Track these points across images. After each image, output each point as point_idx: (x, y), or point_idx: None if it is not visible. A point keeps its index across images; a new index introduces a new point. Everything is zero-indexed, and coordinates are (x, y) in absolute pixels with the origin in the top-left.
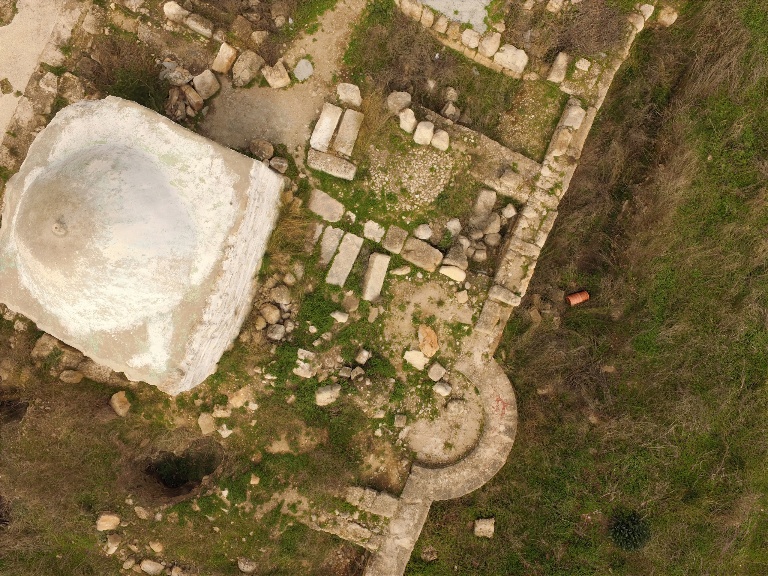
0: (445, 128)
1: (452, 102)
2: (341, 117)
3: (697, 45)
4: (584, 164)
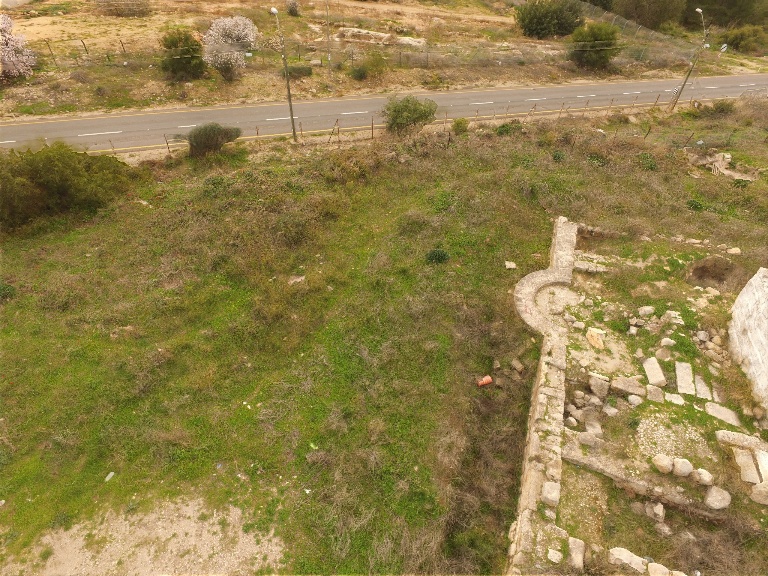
0: (660, 482)
1: (660, 522)
2: (761, 477)
3: (451, 574)
4: (510, 478)
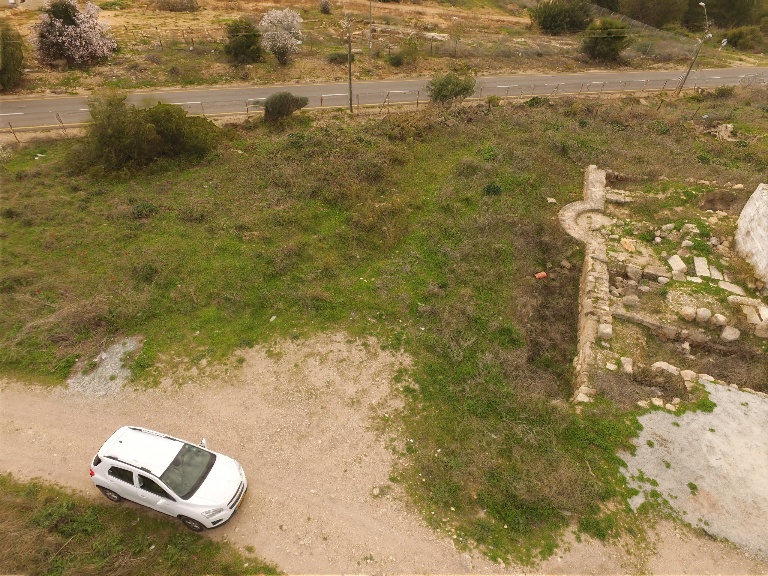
0: (686, 327)
1: (687, 353)
2: None
3: None
4: None
